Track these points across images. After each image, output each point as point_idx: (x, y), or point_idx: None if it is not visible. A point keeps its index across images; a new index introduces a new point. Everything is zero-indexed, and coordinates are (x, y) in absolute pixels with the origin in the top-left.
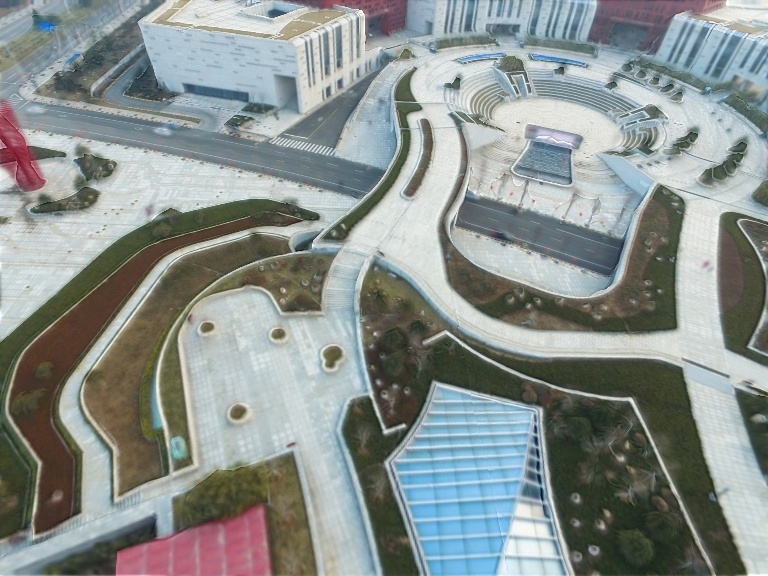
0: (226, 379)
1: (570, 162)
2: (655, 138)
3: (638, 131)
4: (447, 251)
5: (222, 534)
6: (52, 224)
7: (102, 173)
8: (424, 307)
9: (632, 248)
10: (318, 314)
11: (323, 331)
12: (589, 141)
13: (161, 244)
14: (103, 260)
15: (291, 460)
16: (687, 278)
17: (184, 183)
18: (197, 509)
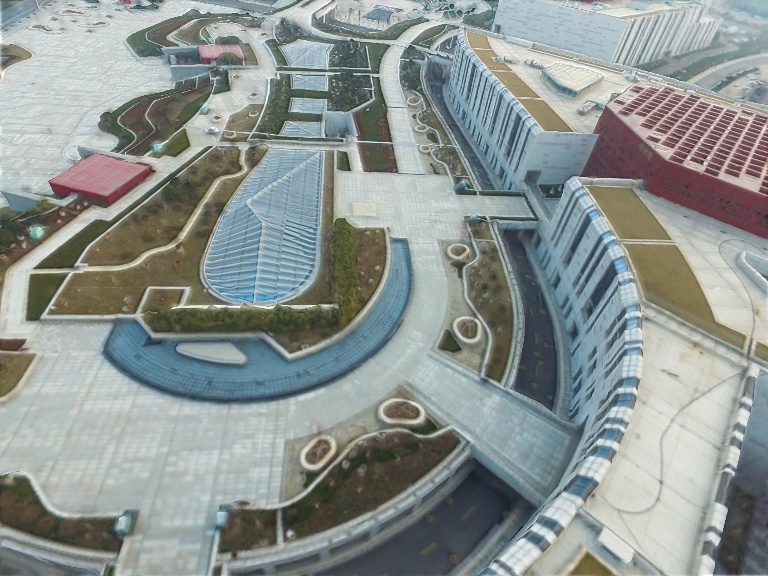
0: (225, 36)
1: (390, 15)
2: (436, 8)
3: (431, 7)
4: (314, 19)
5: (227, 46)
6: (141, 13)
7: (158, 1)
8: (301, 30)
9: (393, 25)
10: (259, 29)
11: (261, 32)
12: (405, 11)
13: None
14: None
15: (248, 44)
16: (410, 32)
17: (198, 8)
18: (220, 39)
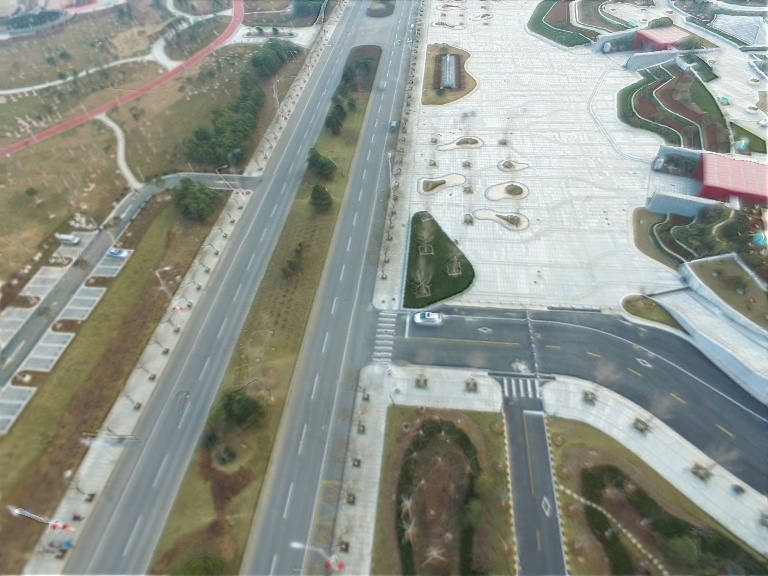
0: None
1: None
2: None
3: None
4: None
5: None
6: None
7: None
8: None
9: None
10: (655, 7)
11: None
12: None
13: (563, 1)
14: (541, 6)
15: None
16: None
17: None
18: (657, 22)
